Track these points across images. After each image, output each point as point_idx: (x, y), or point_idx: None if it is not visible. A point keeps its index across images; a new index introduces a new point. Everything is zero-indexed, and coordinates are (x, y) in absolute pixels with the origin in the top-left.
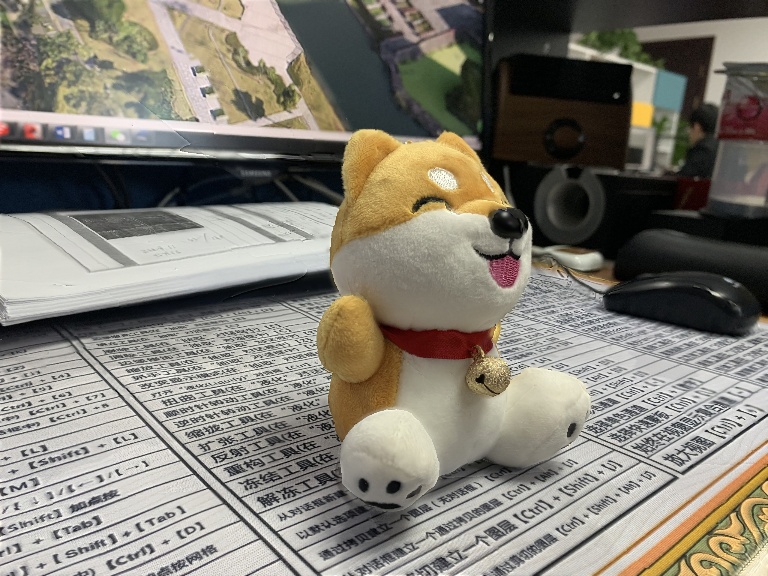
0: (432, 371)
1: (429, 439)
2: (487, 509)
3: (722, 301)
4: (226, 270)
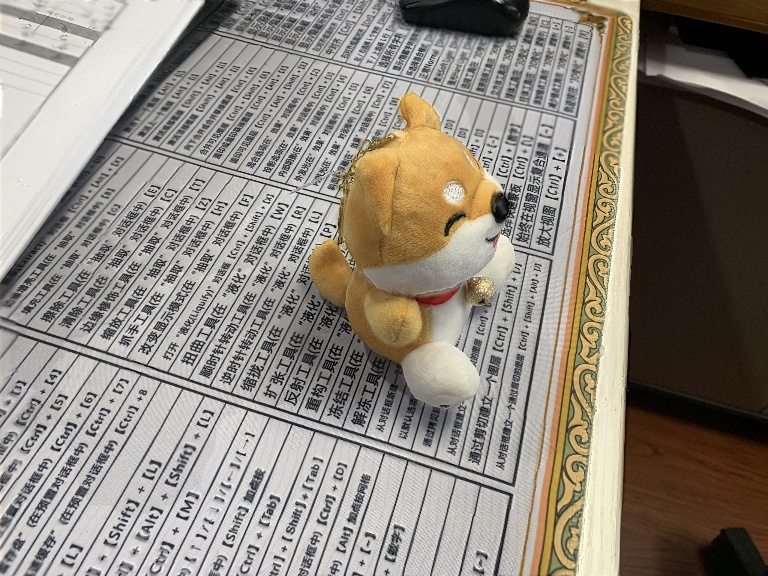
0: (450, 308)
1: (468, 358)
2: (477, 352)
3: (507, 9)
4: (70, 152)
